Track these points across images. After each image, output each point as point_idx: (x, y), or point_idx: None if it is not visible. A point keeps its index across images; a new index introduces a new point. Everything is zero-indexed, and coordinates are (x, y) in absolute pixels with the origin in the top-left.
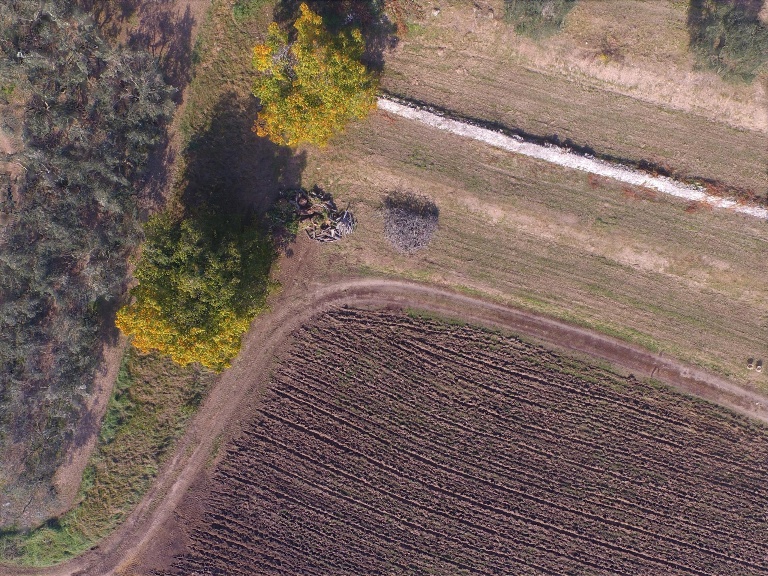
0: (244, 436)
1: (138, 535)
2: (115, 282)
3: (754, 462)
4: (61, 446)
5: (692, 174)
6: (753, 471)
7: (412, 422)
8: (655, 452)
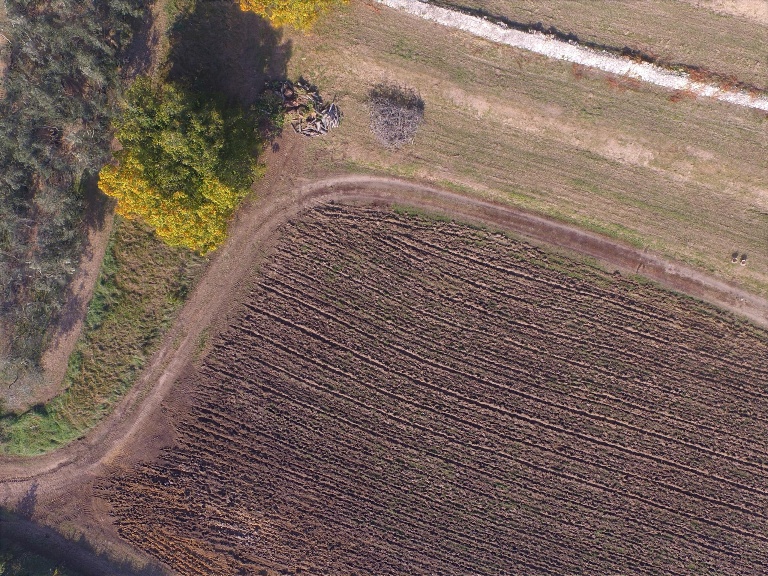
0: (231, 330)
1: (125, 427)
2: (99, 155)
3: (739, 358)
4: (47, 331)
5: (676, 61)
6: (738, 366)
7: (398, 317)
8: (640, 347)
